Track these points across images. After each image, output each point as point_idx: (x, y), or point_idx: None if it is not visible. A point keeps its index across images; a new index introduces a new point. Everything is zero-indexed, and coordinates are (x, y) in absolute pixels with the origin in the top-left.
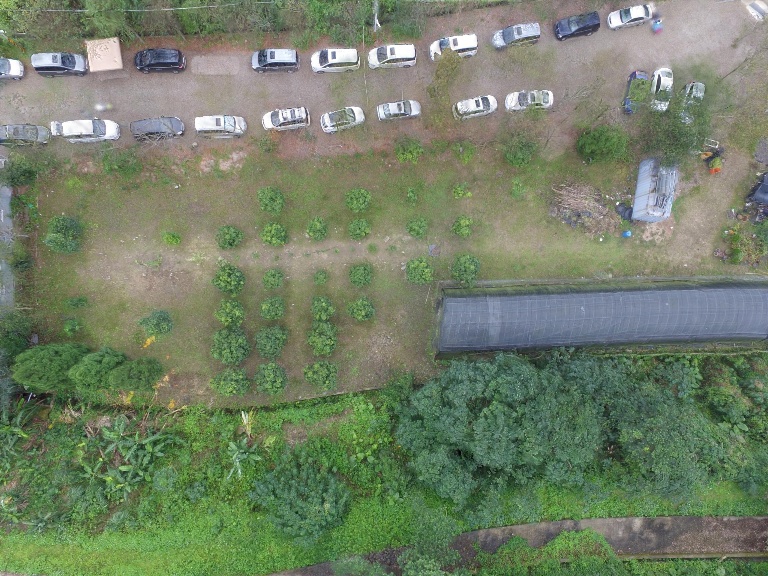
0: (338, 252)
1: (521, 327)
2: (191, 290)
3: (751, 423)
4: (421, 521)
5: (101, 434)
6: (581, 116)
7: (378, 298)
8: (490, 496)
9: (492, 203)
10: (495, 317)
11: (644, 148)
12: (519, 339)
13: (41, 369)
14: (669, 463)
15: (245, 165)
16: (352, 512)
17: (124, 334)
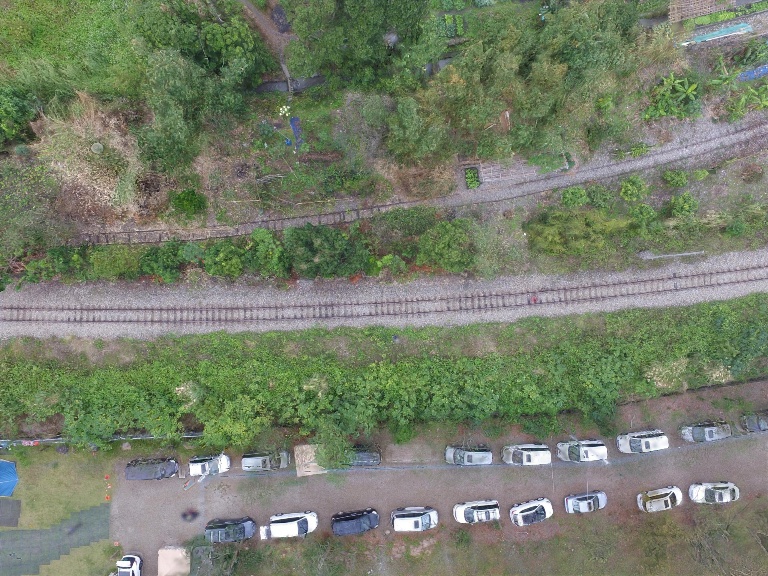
0: None
1: None
2: None
3: None
4: None
5: None
6: (763, 504)
7: None
8: None
9: None
10: None
11: None
12: None
13: None
14: None
15: (434, 551)
16: None
17: None
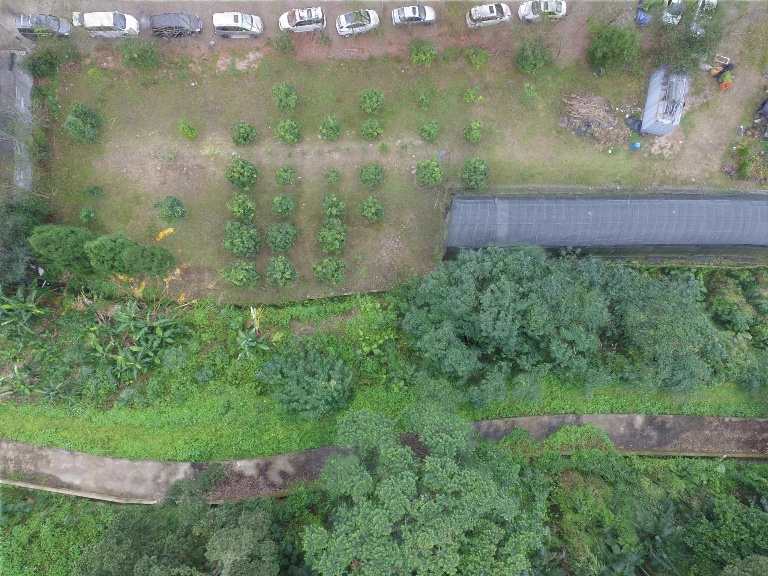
0: (350, 152)
1: (528, 229)
2: (204, 186)
3: (755, 332)
4: (426, 389)
5: (112, 323)
6: None
7: (388, 201)
8: (494, 376)
9: (503, 111)
10: (503, 218)
11: (655, 62)
12: (526, 242)
13: (57, 241)
14: (672, 356)
15: (261, 65)
16: (357, 398)
17: (137, 227)
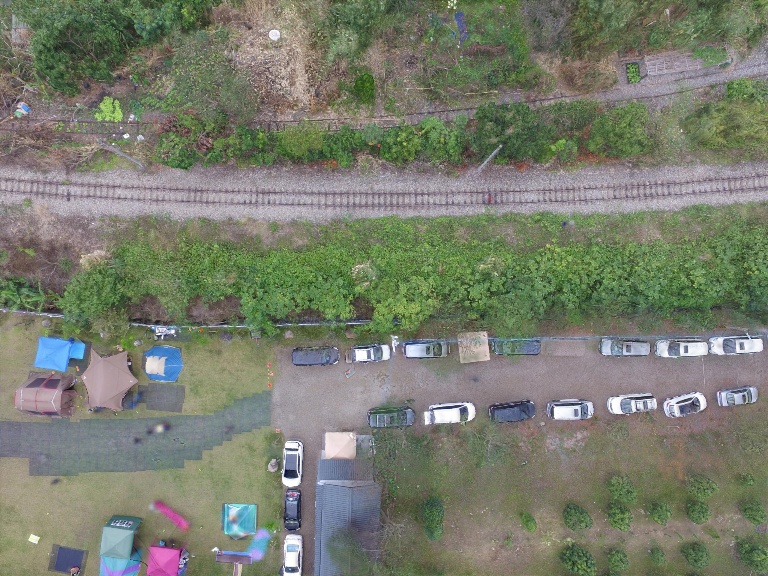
0: (676, 532)
1: None
2: (532, 561)
3: None
4: None
5: None
6: None
7: (705, 572)
8: None
9: None
10: None
11: None
12: None
13: None
14: None
15: (587, 443)
16: None
17: None
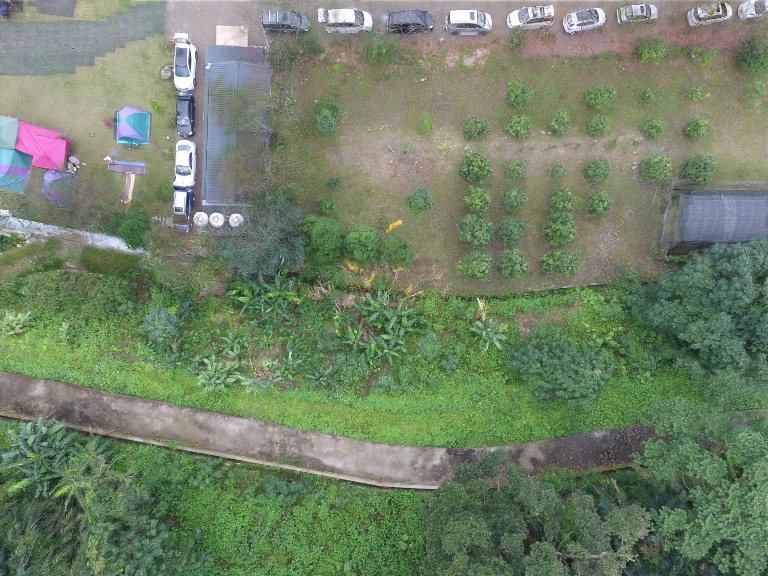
0: (576, 148)
1: (756, 225)
2: (432, 180)
3: None
4: (714, 378)
5: None
6: None
7: None
8: (761, 367)
9: (720, 109)
10: (731, 214)
11: None
12: (752, 237)
13: (329, 230)
14: None
15: (487, 62)
16: (603, 388)
17: (368, 219)
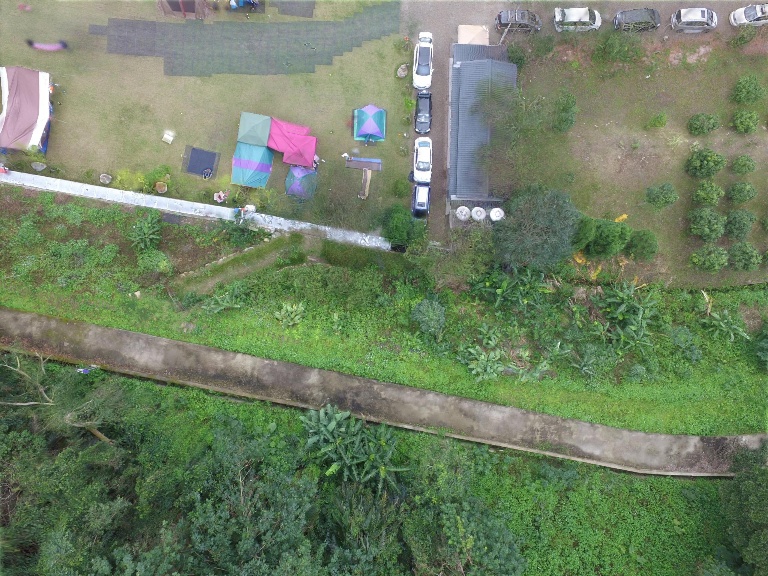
0: None
1: None
2: (656, 175)
3: None
4: None
5: None
6: None
7: None
8: None
9: None
10: None
11: None
12: None
13: None
14: None
15: (710, 59)
16: None
17: (594, 213)
